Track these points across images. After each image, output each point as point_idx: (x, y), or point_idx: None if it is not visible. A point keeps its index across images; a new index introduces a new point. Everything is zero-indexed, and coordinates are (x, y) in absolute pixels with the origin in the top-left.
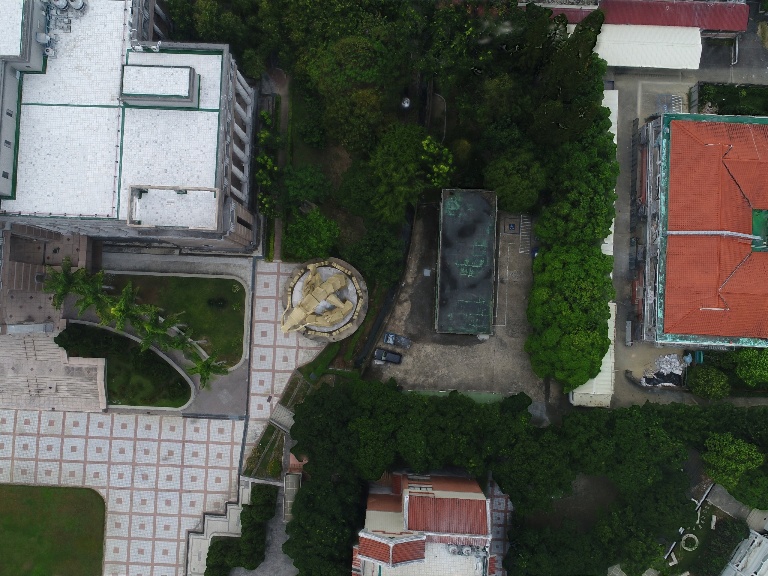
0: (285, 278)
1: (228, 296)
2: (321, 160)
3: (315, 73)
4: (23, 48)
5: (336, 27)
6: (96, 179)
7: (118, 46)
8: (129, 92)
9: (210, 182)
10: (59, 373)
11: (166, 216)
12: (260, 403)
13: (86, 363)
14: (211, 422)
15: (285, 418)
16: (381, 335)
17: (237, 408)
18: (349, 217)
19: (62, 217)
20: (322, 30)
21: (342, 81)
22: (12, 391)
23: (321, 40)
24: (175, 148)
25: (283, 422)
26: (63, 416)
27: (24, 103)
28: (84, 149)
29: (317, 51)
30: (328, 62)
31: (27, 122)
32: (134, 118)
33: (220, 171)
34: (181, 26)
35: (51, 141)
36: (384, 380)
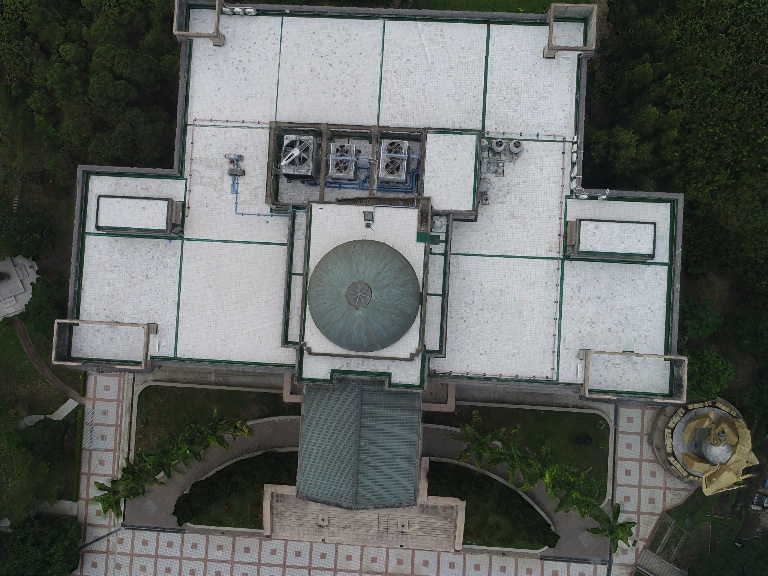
0: (651, 413)
1: (590, 432)
2: (690, 286)
3: (727, 207)
4: (477, 203)
5: (757, 159)
6: (533, 337)
7: (556, 192)
8: (586, 249)
9: (659, 343)
10: (413, 511)
11: (611, 379)
12: (624, 547)
13: (446, 503)
14: (571, 566)
15: (655, 566)
16: (760, 478)
17: (599, 552)
18: (722, 349)
19: (496, 378)
20: (730, 158)
21: (766, 219)
22: (359, 527)
23: (724, 168)
24: (620, 305)
25: (653, 570)
26: (412, 554)
27: (453, 253)
28: (520, 304)
29: (721, 180)
30: (751, 198)
31: (457, 274)
32: (574, 271)
33: (676, 333)
34: (597, 161)
35: (484, 295)
36: (762, 527)
